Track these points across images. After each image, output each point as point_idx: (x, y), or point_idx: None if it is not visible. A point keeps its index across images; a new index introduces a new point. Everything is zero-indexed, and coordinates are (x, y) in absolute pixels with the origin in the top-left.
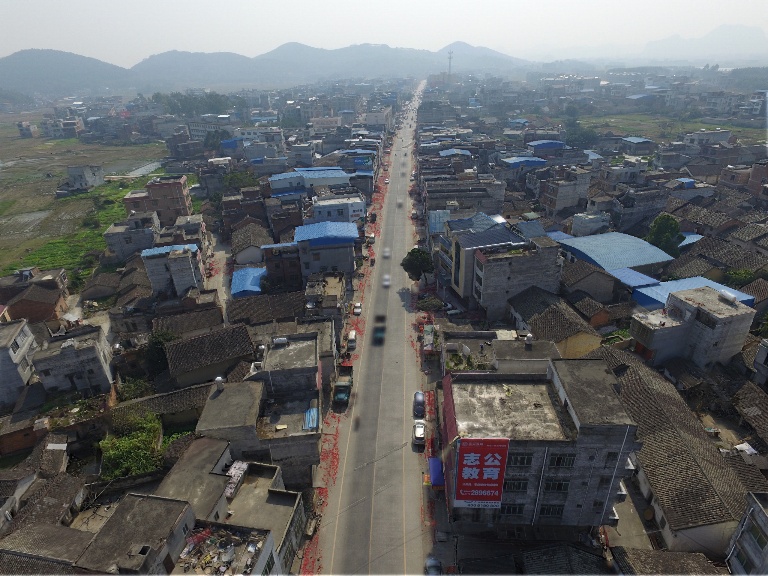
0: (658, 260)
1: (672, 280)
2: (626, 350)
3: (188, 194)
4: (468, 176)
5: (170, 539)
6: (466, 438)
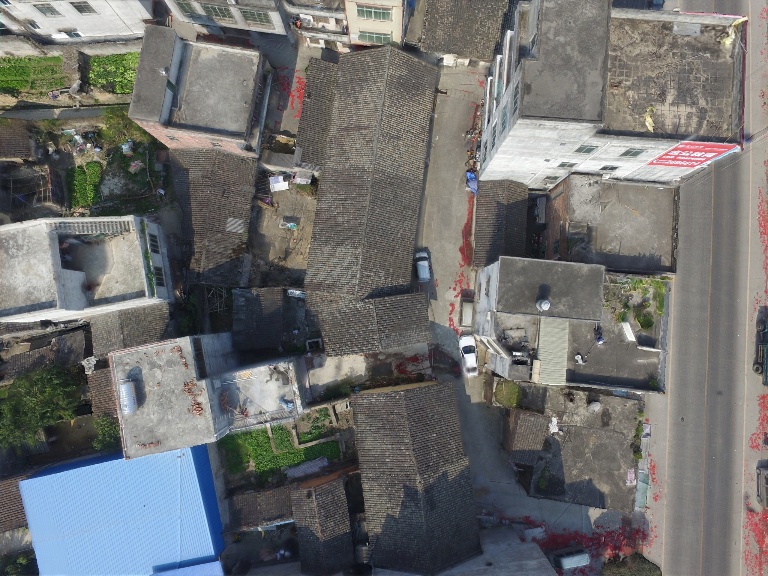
0: None
1: None
2: (309, 400)
3: None
4: None
5: None
6: None
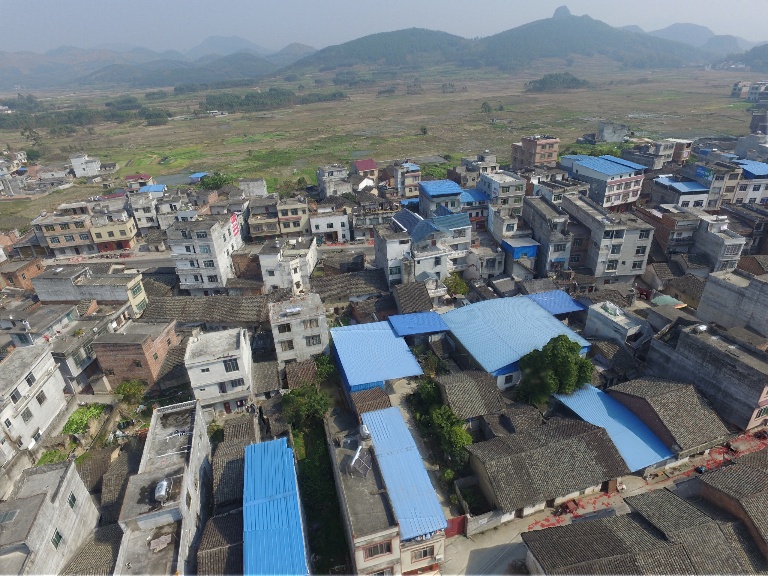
0: (478, 356)
1: (410, 348)
2: None
3: (552, 154)
4: (671, 217)
5: (198, 198)
6: (195, 216)
